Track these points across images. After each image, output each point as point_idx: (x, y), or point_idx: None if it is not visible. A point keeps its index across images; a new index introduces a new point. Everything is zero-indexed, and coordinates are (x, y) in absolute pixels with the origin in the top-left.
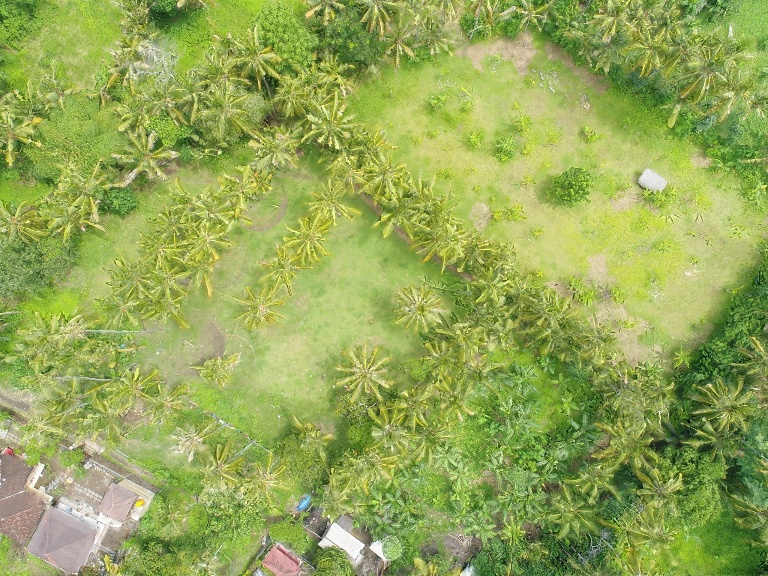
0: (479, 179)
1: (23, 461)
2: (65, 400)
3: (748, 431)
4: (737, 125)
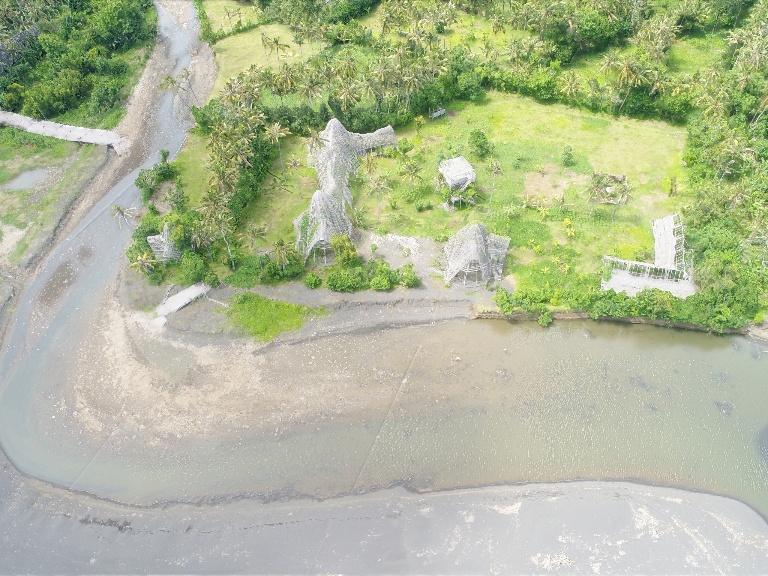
0: None
1: None
2: None
3: None
4: None
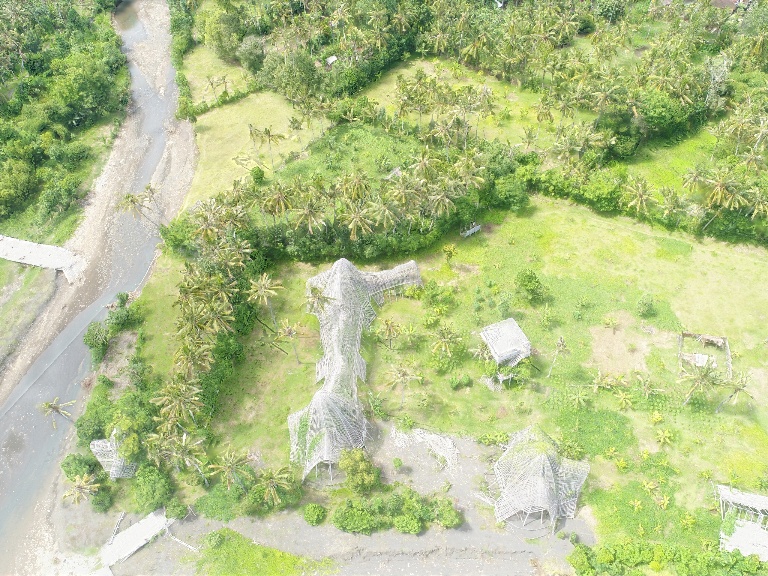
0: (516, 108)
1: (715, 7)
2: (703, 4)
3: (398, 3)
4: (384, 108)
